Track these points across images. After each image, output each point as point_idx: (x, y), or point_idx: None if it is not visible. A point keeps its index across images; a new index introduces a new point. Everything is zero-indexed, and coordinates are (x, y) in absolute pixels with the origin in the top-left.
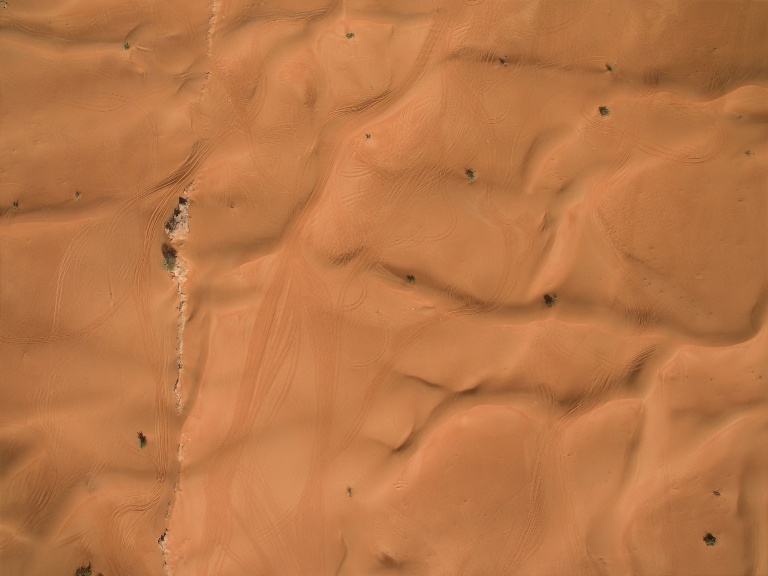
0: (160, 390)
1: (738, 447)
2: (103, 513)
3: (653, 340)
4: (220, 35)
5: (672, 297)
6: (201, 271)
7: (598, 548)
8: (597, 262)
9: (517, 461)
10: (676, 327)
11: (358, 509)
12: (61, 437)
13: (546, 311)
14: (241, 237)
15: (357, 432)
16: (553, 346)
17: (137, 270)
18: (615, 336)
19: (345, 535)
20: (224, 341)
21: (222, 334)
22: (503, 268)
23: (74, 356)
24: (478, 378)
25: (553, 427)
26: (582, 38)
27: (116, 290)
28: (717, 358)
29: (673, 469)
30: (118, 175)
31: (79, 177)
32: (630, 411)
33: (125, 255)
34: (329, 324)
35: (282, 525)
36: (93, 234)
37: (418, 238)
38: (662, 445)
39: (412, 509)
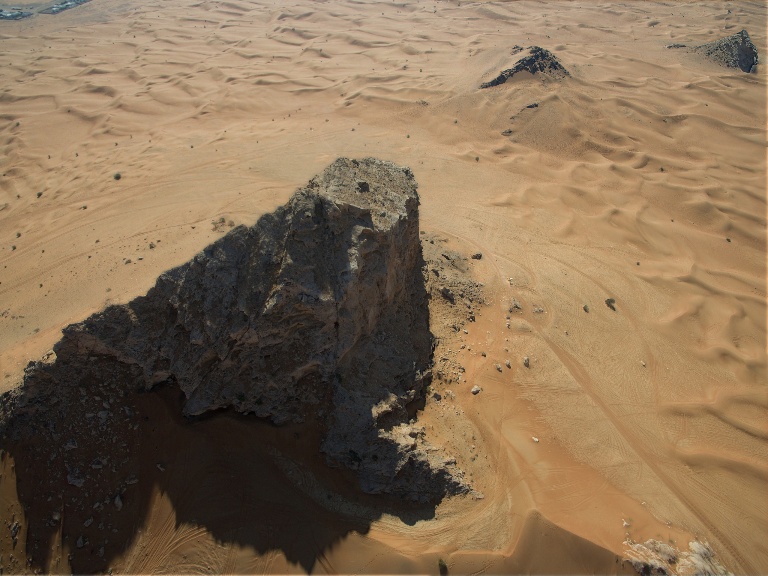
0: None
1: None
2: None
3: None
4: (723, 8)
5: None
6: None
7: None
8: None
9: None
10: None
11: None
12: None
13: None
14: None
15: None
16: None
17: None
18: None
19: None
20: None
21: None
22: None
23: None
24: None
25: None
26: (650, 3)
27: None
28: None
29: None
30: (741, 3)
31: (749, 5)
32: None
33: None
34: None
35: None
36: None
37: None
38: None
39: None
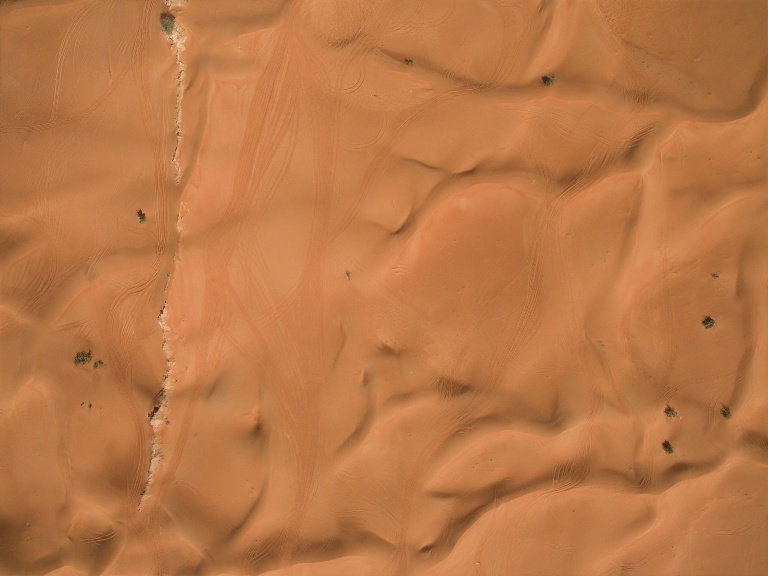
0: (159, 165)
1: (737, 227)
2: (103, 303)
3: (651, 118)
4: None
5: (670, 79)
6: (199, 39)
7: (596, 331)
8: (595, 44)
9: (515, 243)
10: (674, 104)
11: (357, 294)
12: (61, 227)
13: (544, 89)
14: (239, 12)
15: (355, 214)
16: (551, 126)
17: (136, 44)
18: (613, 113)
19: (344, 321)
20: (222, 109)
21: (220, 102)
22: (501, 50)
23: (73, 139)
24: (476, 159)
25: (551, 205)
26: None
27: (115, 67)
28: (715, 135)
29: (671, 251)
30: None
31: None
32: (628, 187)
33: (124, 31)
34: (327, 106)
35: (281, 309)
36: (92, 14)
37: (416, 24)
38: (660, 224)
39: (411, 296)
